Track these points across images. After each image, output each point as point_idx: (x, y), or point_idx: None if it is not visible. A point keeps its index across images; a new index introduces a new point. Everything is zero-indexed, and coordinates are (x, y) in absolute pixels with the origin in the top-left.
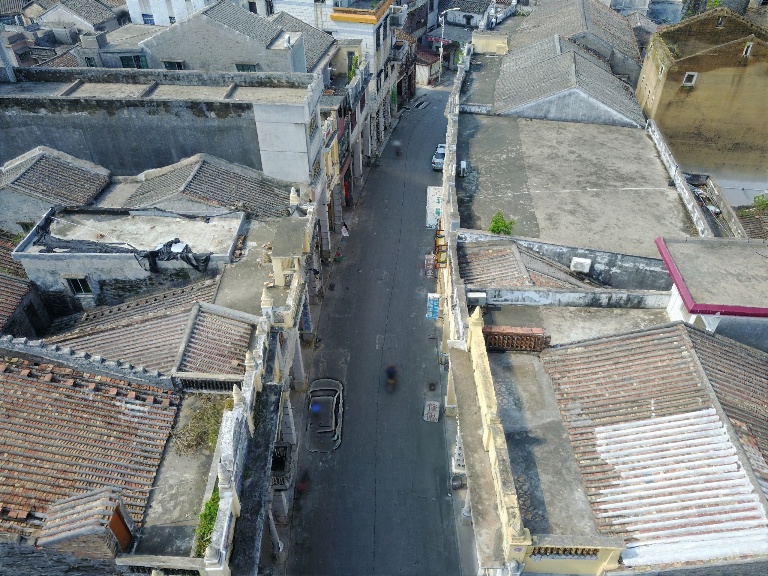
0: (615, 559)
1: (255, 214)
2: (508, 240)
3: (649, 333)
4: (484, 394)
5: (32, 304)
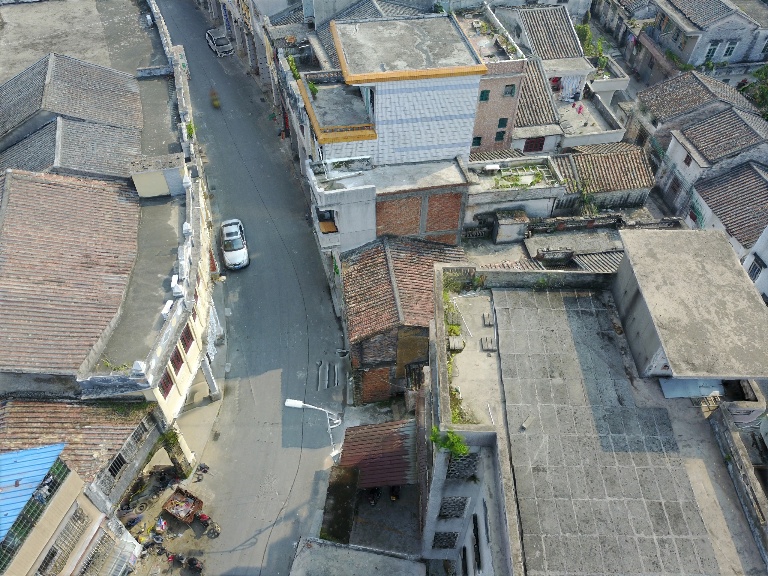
0: None
1: None
2: None
3: None
4: None
5: None
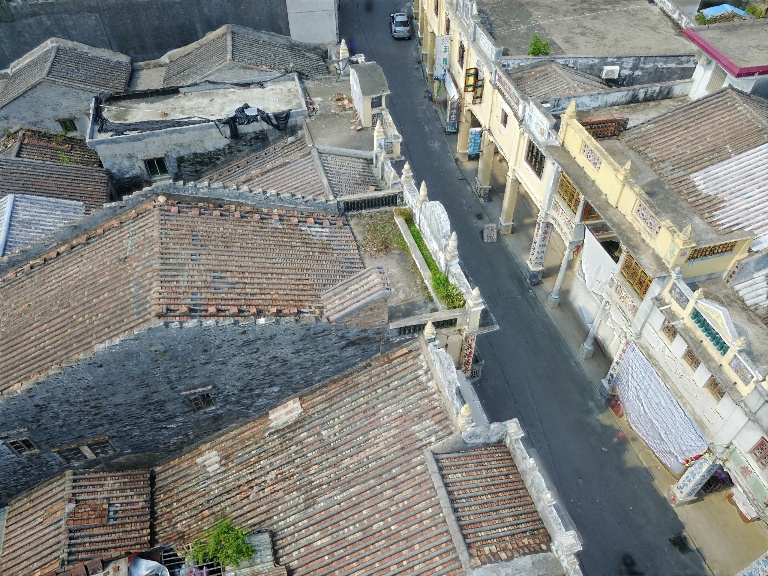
0: (746, 248)
1: (305, 74)
2: (547, 60)
3: (705, 101)
4: (606, 162)
5: (111, 193)
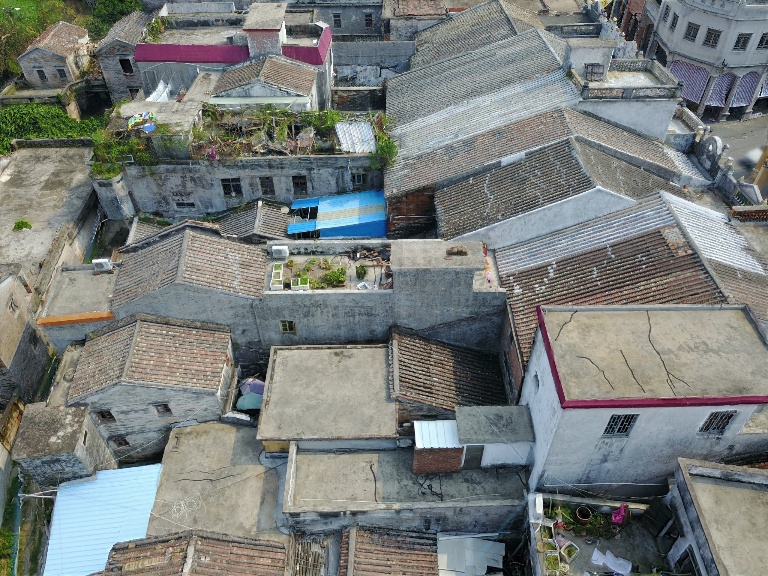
0: None
1: None
2: None
3: (763, 318)
4: None
5: None
